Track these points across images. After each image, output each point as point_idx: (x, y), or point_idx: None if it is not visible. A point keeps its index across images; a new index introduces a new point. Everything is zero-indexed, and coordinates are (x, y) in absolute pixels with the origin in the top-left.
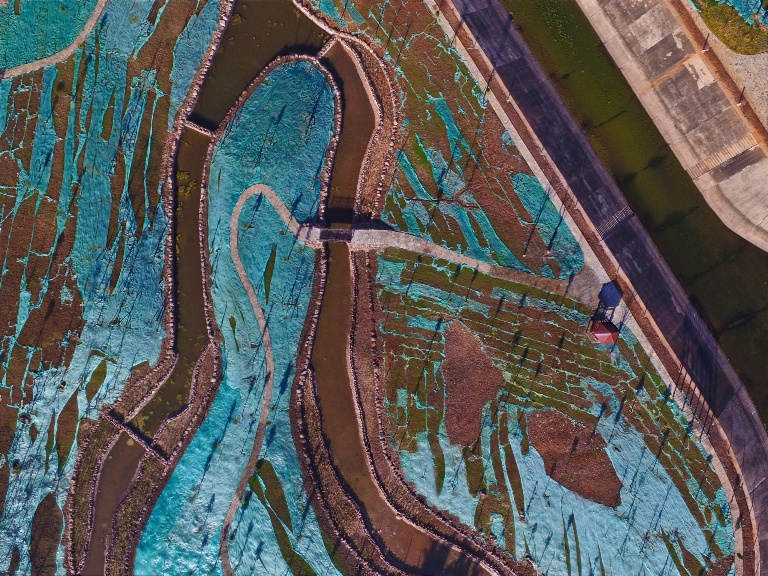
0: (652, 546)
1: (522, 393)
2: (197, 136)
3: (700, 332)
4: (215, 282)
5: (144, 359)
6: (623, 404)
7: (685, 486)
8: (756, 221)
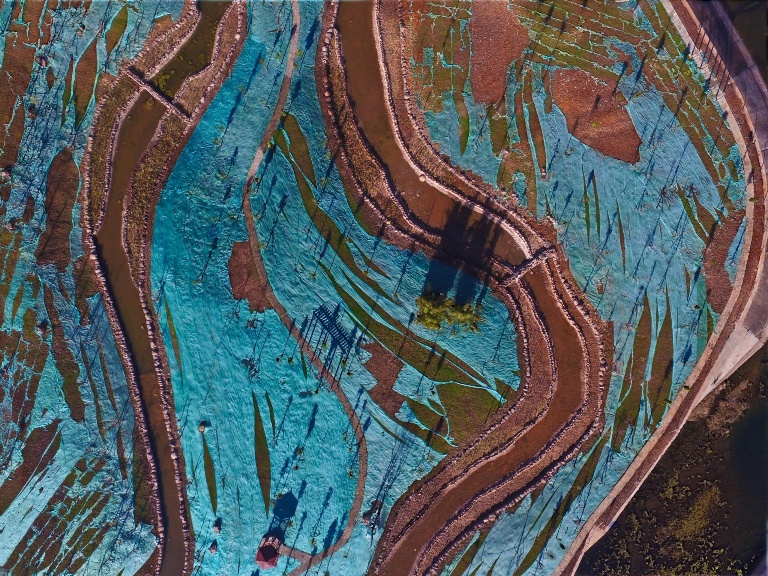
0: (668, 201)
1: (546, 52)
2: None
3: (717, 9)
4: None
5: (166, 12)
6: (644, 63)
7: (701, 143)
8: None
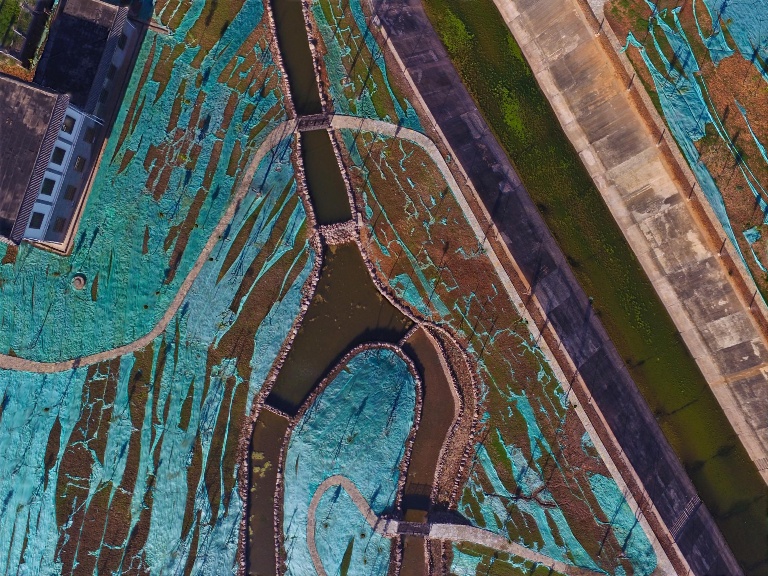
0: None
1: None
2: (274, 416)
3: None
4: (289, 568)
5: None
6: None
7: None
8: None
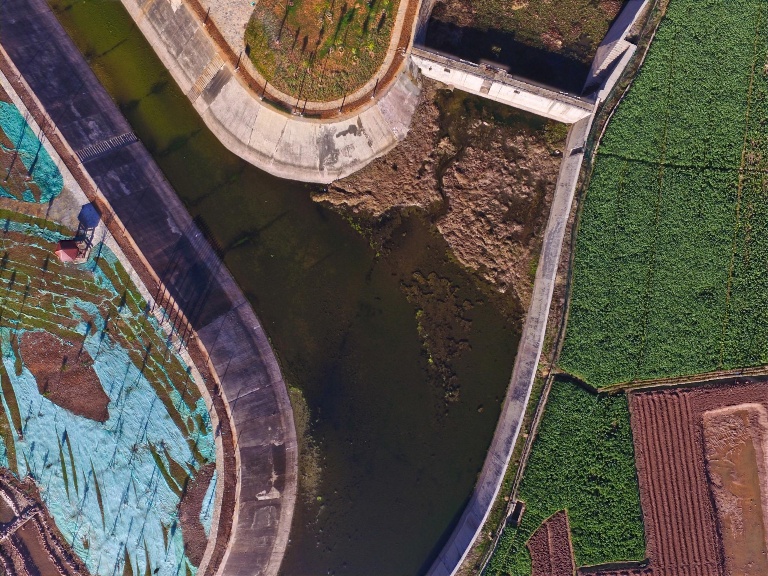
0: (140, 457)
1: (13, 316)
2: None
3: (199, 251)
4: None
5: None
6: (107, 322)
7: (168, 398)
8: (245, 141)
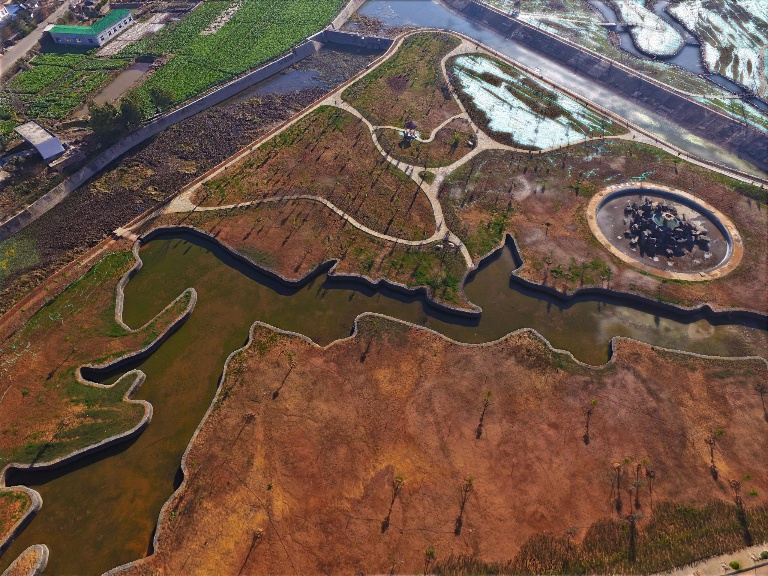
0: None
1: None
2: None
3: None
4: None
5: None
6: None
7: None
8: None
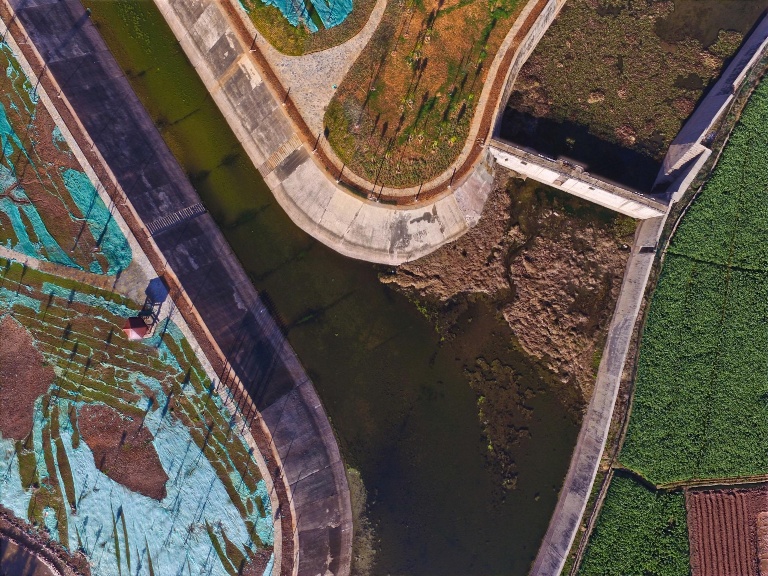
0: (196, 537)
1: (73, 387)
2: None
3: (264, 328)
4: None
5: None
6: (170, 398)
7: (228, 478)
8: (316, 219)
